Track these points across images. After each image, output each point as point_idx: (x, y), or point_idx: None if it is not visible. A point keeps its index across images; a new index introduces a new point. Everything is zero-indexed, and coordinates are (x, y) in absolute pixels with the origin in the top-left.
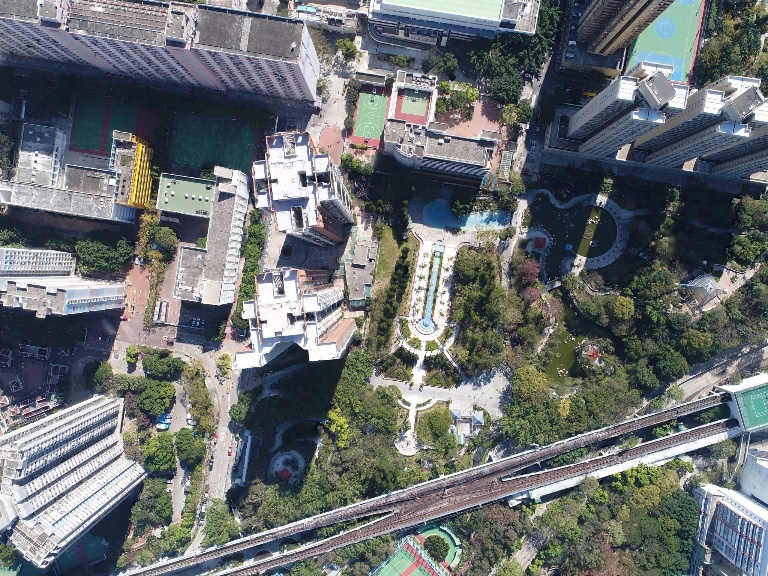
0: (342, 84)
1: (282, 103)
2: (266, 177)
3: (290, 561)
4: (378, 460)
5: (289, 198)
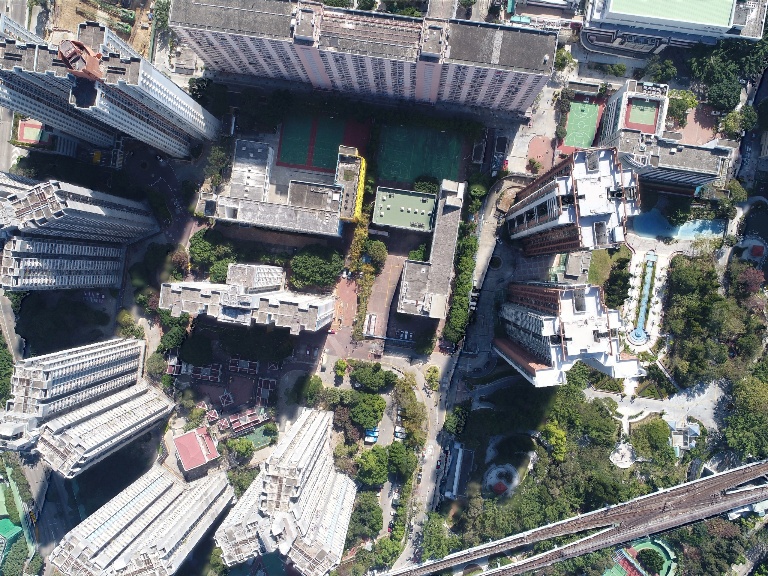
0: (551, 94)
1: (490, 114)
2: (568, 193)
3: (508, 575)
4: (596, 473)
5: (597, 214)
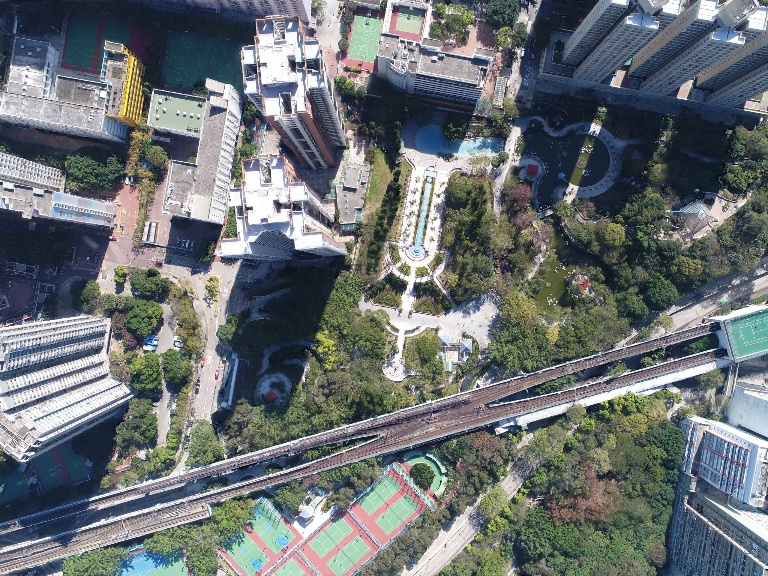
0: (337, 6)
1: None
2: (255, 63)
3: (274, 483)
4: (365, 384)
5: (278, 83)
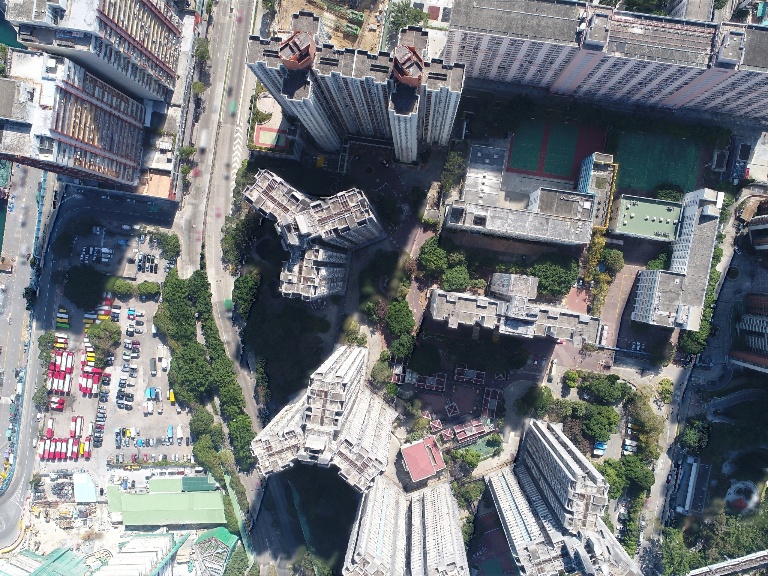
0: None
1: (731, 121)
2: None
3: None
4: None
5: None
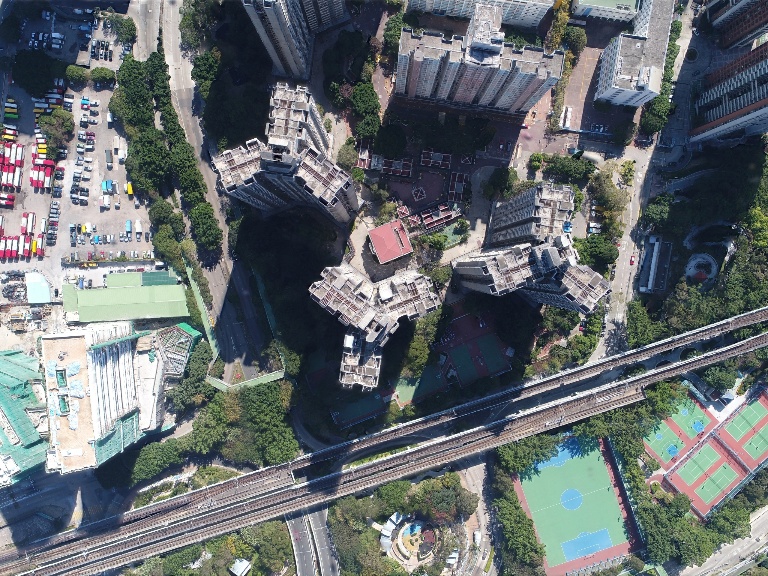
0: None
1: None
2: None
3: (710, 362)
4: None
5: None
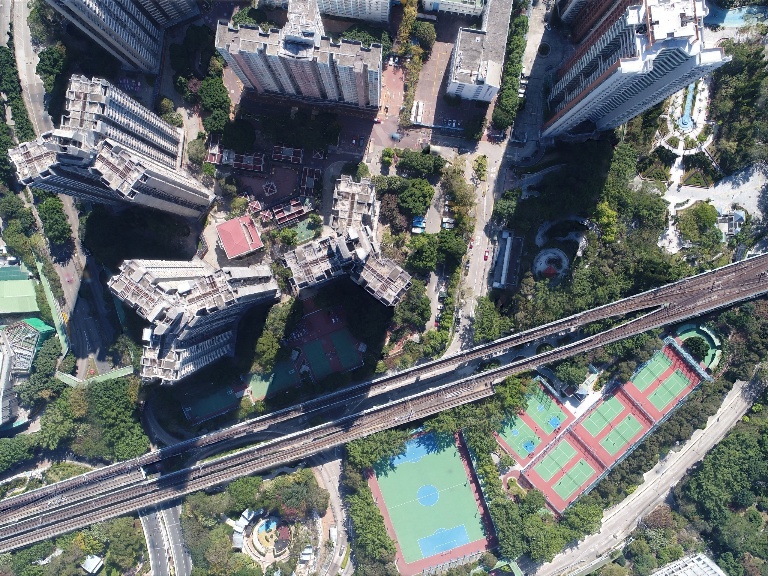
0: None
1: None
2: None
3: None
4: (645, 255)
5: None
